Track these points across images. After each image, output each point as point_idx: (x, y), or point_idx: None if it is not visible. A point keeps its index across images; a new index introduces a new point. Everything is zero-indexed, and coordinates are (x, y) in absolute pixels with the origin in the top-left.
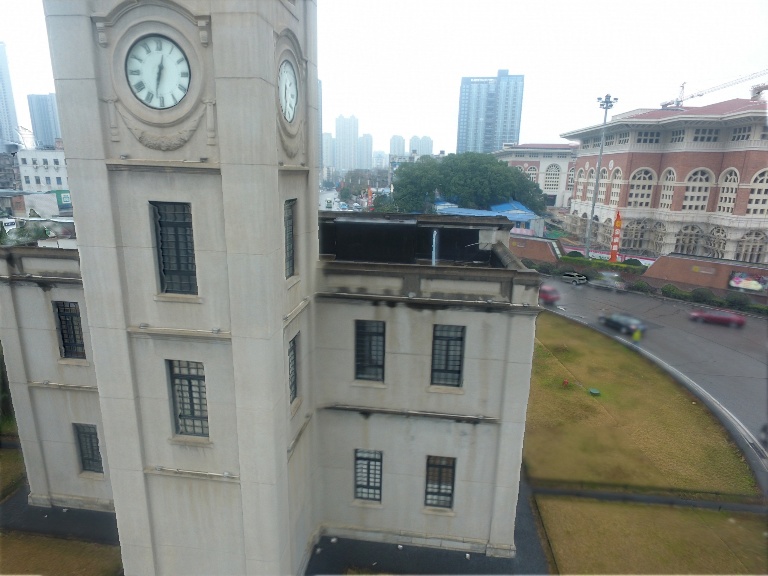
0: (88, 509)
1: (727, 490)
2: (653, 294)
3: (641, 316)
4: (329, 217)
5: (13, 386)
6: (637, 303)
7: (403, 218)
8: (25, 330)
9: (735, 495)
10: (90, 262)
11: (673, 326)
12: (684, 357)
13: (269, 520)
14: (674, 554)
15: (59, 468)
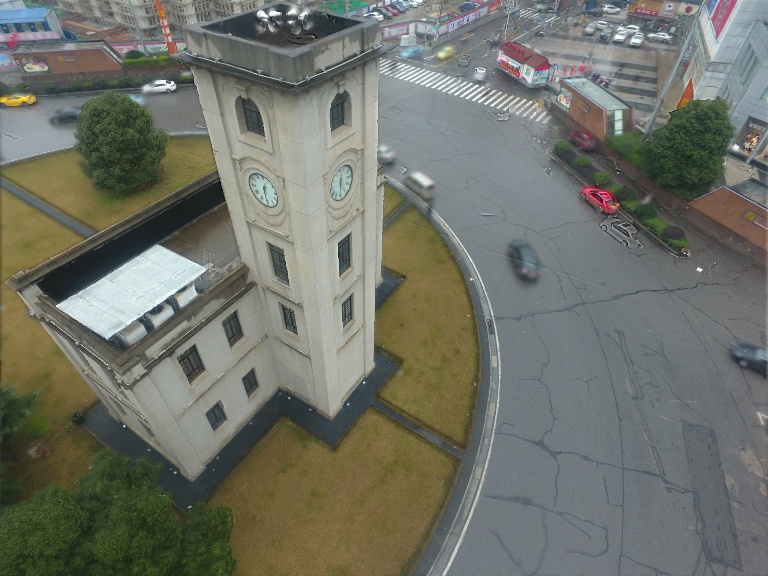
0: (226, 445)
1: (397, 203)
2: None
3: None
4: (216, 178)
5: (165, 432)
6: None
7: None
8: (162, 393)
9: (400, 203)
10: (321, 288)
11: None
12: None
13: (372, 328)
14: (411, 239)
15: (202, 445)
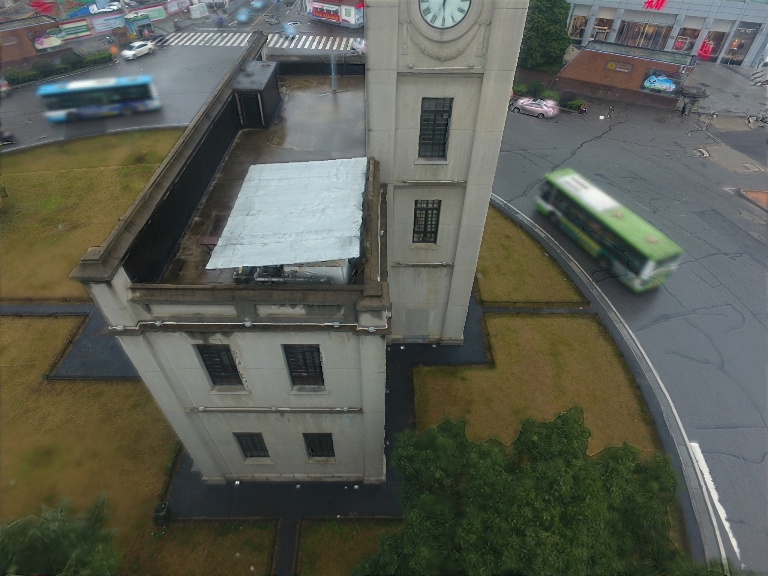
0: None
1: None
2: (1, 88)
3: (64, 109)
4: (230, 93)
5: None
6: (22, 102)
7: (245, 64)
8: None
9: None
10: None
11: (100, 102)
12: (166, 115)
13: None
14: None
15: None
